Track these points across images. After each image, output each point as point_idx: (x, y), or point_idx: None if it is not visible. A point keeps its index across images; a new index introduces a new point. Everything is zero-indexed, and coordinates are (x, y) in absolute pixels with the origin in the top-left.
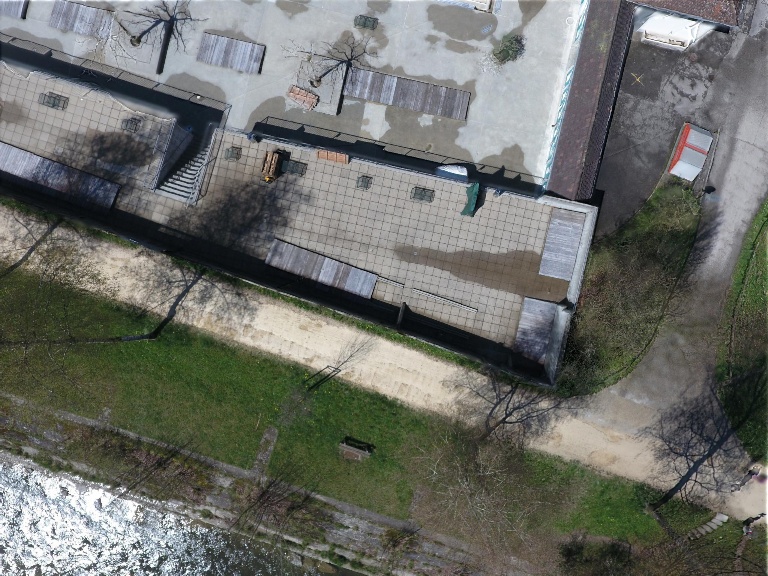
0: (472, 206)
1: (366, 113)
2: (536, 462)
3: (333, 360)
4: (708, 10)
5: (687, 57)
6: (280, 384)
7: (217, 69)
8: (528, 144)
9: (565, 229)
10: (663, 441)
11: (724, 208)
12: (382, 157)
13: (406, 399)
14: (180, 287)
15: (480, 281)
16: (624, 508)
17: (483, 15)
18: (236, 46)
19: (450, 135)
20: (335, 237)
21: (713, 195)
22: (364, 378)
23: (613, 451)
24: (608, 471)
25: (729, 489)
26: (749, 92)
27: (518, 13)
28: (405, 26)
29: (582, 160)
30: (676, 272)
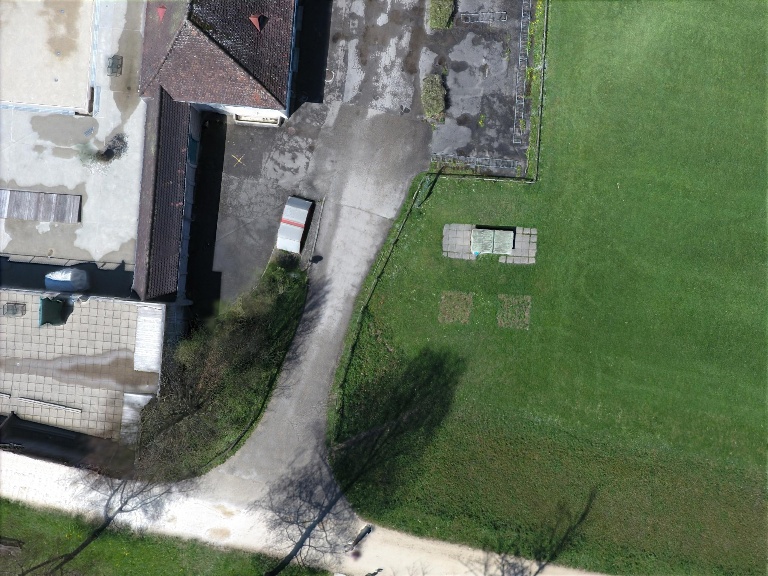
0: None
1: None
2: (158, 545)
3: None
4: (250, 100)
5: (285, 132)
6: None
7: None
8: None
9: (150, 325)
10: (273, 512)
11: (332, 276)
12: (8, 268)
13: (26, 501)
14: None
15: (81, 383)
16: None
17: (84, 119)
18: None
19: (69, 238)
20: None
21: (321, 264)
22: None
23: (227, 527)
24: (225, 546)
25: (343, 550)
26: (351, 157)
27: (116, 113)
28: (12, 140)
29: (145, 262)
30: (284, 346)
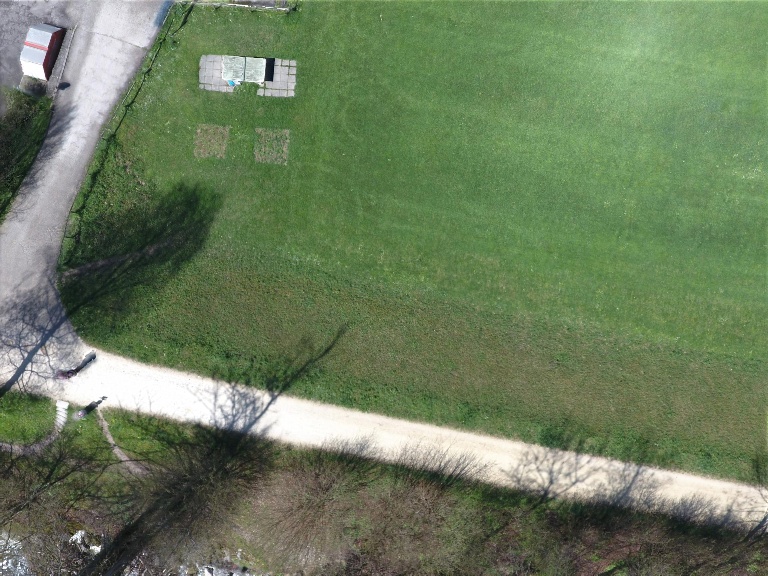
0: None
1: None
2: None
3: None
4: None
5: None
6: None
7: None
8: None
9: None
10: None
11: (78, 102)
12: None
13: None
14: None
15: None
16: None
17: None
18: None
19: None
20: None
21: (67, 91)
22: None
23: None
24: None
25: (66, 376)
26: None
27: None
28: None
29: None
30: (22, 170)
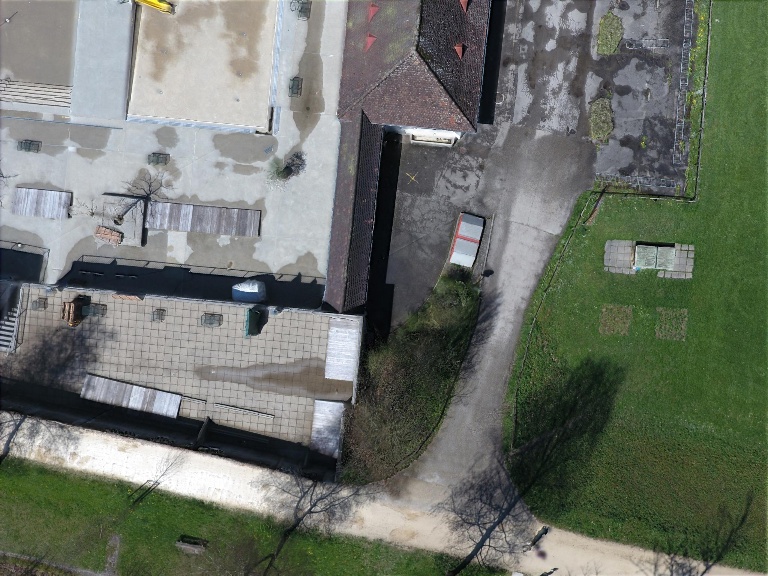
0: (246, 332)
1: (170, 241)
2: (344, 544)
3: (151, 475)
4: (445, 123)
5: (457, 151)
6: (111, 499)
7: (32, 219)
8: (319, 250)
9: (342, 335)
10: (455, 514)
11: (503, 289)
12: (189, 279)
13: (220, 502)
14: (10, 427)
15: (274, 390)
16: (429, 575)
17: (264, 138)
18: (46, 196)
19: (248, 251)
20: (140, 366)
21: (492, 278)
22: (181, 488)
23: (411, 527)
24: (409, 546)
25: (521, 550)
26: (519, 176)
27: (296, 132)
28: (195, 157)
29: (344, 276)
30: (460, 355)
